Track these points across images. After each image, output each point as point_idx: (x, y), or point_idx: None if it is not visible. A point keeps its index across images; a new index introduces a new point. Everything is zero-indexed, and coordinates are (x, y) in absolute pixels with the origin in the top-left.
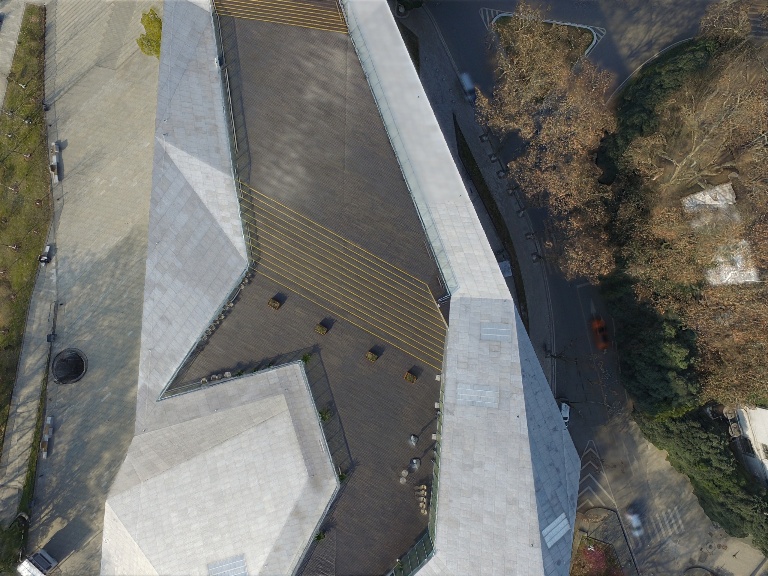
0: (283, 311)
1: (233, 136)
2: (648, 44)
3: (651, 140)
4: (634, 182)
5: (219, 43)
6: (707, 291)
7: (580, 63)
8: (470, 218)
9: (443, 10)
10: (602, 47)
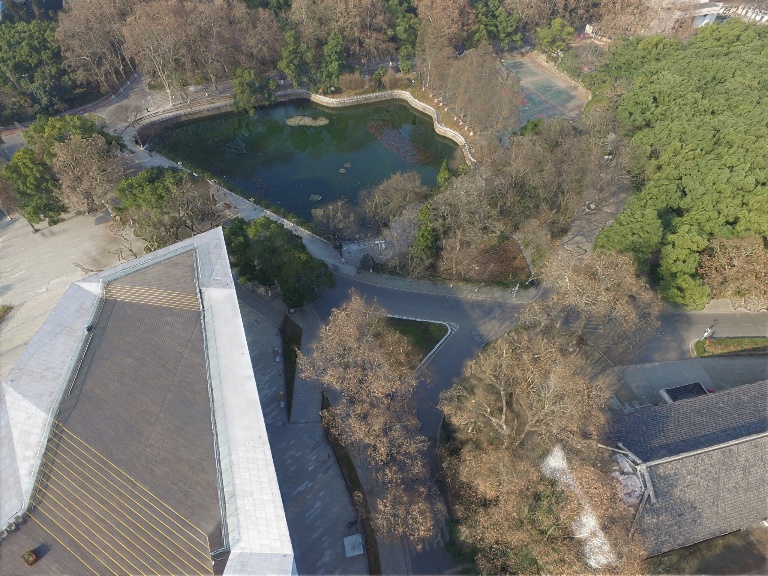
0: (37, 568)
1: (71, 383)
2: (495, 335)
3: (451, 391)
4: (480, 444)
5: (96, 316)
6: (536, 555)
7: (376, 328)
8: (265, 459)
9: (326, 311)
10: (457, 337)
